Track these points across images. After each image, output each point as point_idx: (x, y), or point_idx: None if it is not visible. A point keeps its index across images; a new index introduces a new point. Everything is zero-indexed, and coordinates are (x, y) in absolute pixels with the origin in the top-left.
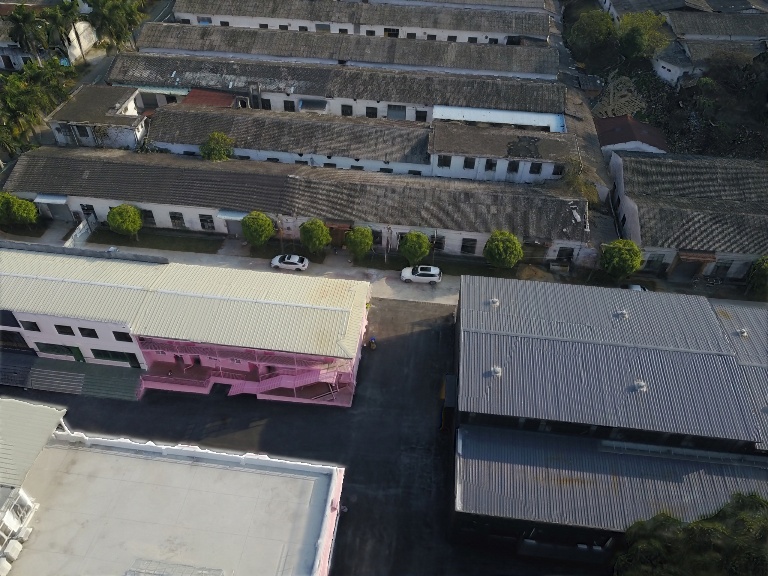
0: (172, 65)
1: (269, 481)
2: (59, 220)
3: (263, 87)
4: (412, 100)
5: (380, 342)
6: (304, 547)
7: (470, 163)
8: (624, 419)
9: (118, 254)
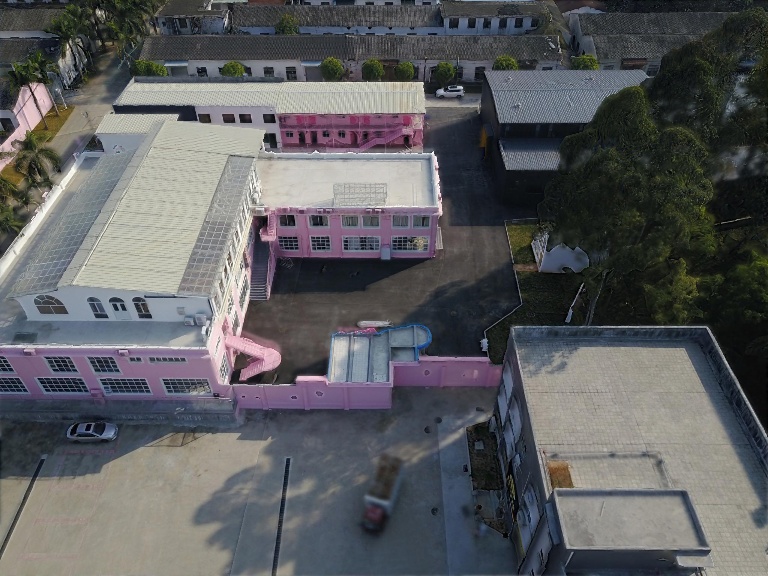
0: None
1: (393, 163)
2: None
3: None
4: None
5: (432, 126)
6: (425, 184)
7: (472, 23)
8: None
9: (249, 78)
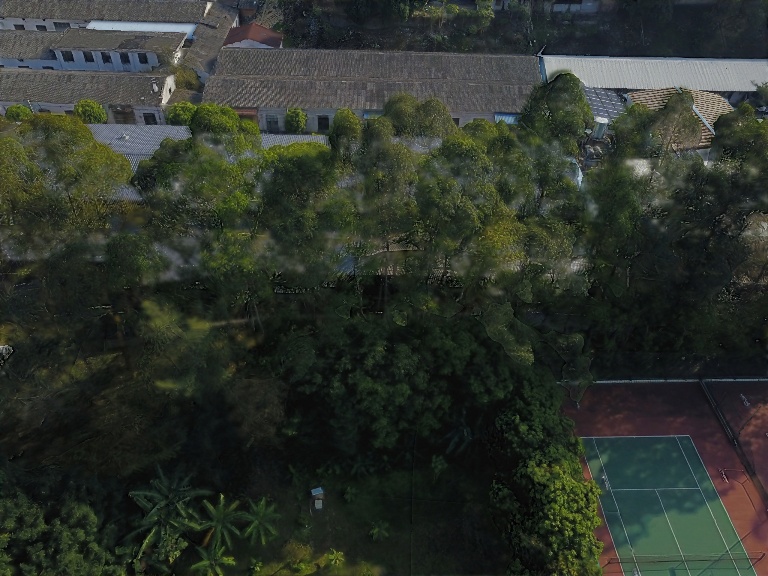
0: None
1: None
2: None
3: None
4: (72, 17)
5: None
6: None
7: (89, 57)
8: None
9: None
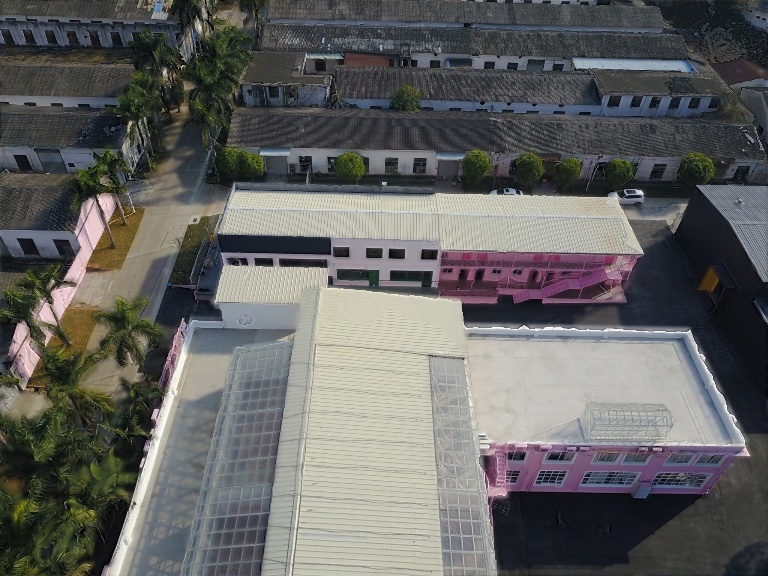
0: (319, 32)
1: (636, 348)
2: (273, 174)
3: (412, 48)
4: (552, 54)
5: None
6: (697, 390)
7: (637, 102)
8: None
9: (389, 188)
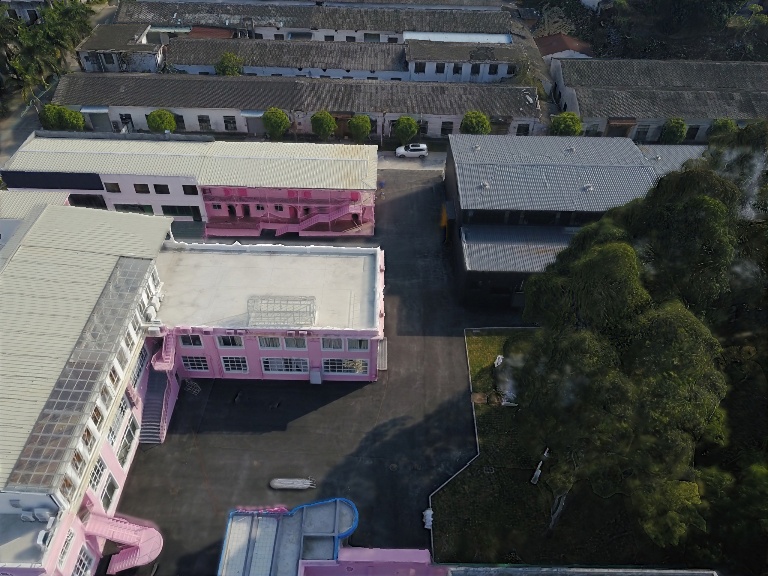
0: (172, 8)
1: (331, 260)
2: (99, 131)
3: (256, 23)
4: (385, 28)
5: (388, 196)
6: (365, 291)
7: (441, 68)
8: (579, 206)
9: (172, 136)
